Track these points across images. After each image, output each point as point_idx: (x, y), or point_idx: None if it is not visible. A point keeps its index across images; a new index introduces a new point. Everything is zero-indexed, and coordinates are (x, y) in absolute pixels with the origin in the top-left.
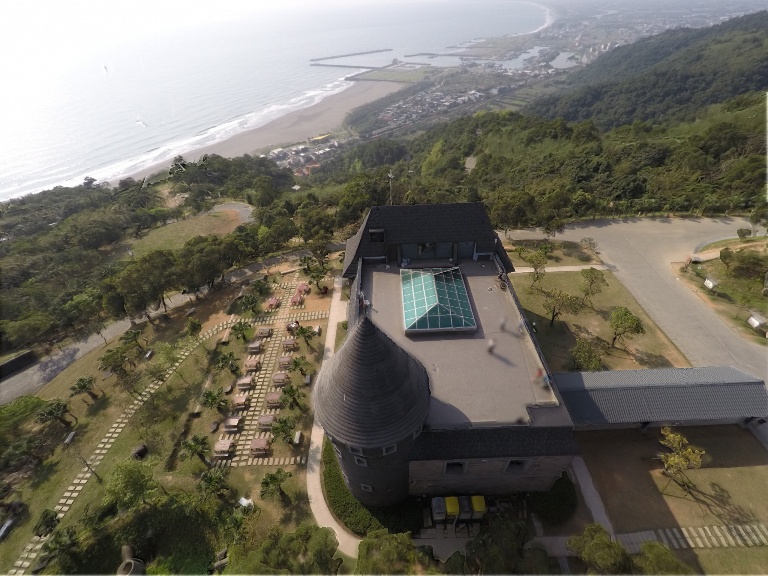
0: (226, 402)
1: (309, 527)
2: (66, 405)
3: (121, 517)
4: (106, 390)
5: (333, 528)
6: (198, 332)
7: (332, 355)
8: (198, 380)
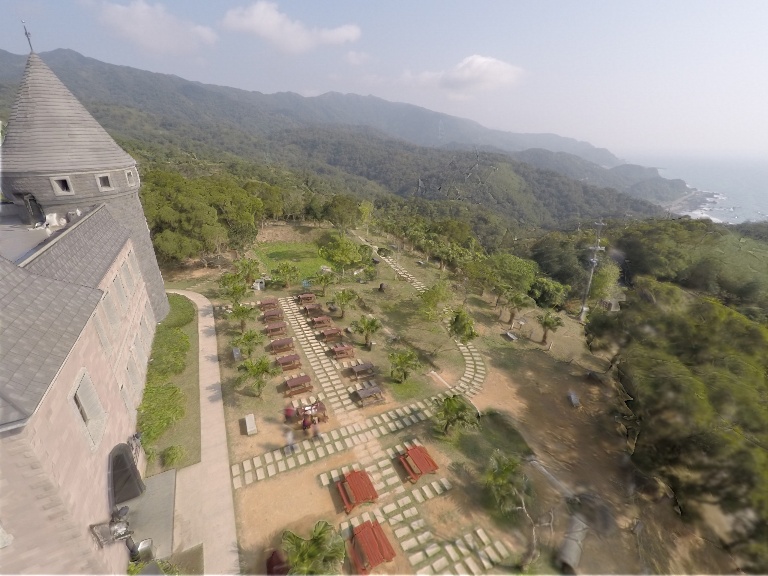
0: (327, 304)
1: (182, 250)
2: (486, 279)
3: (352, 271)
4: (496, 311)
5: (179, 293)
6: (458, 336)
7: (203, 392)
8: (405, 332)
